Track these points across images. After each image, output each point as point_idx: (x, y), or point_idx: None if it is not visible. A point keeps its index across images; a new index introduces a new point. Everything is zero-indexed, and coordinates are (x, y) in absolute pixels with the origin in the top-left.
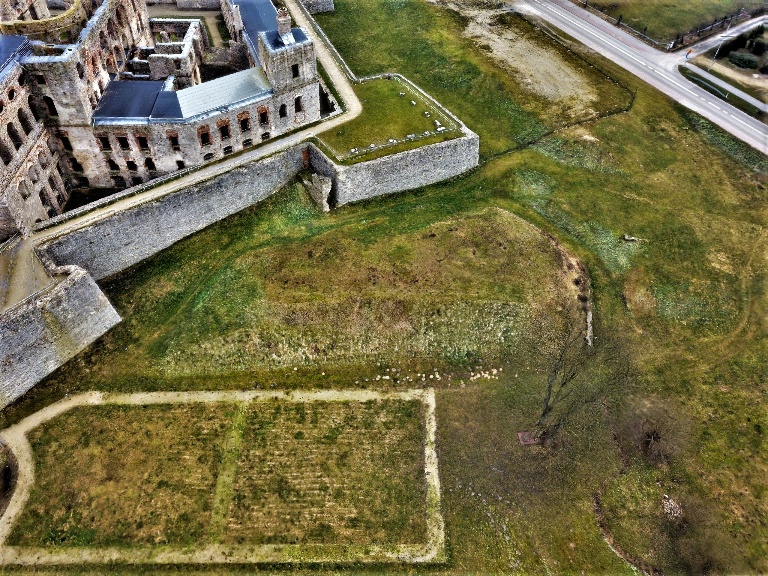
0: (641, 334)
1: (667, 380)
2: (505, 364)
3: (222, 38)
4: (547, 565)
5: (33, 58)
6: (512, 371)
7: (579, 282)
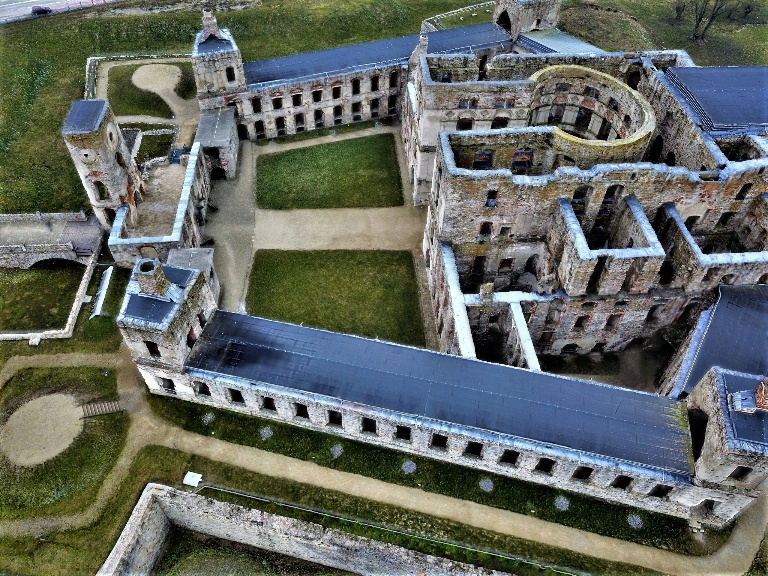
0: (612, 7)
1: (636, 8)
2: (659, 44)
3: (323, 136)
4: (761, 44)
5: (692, 66)
6: (661, 43)
7: (597, 8)
